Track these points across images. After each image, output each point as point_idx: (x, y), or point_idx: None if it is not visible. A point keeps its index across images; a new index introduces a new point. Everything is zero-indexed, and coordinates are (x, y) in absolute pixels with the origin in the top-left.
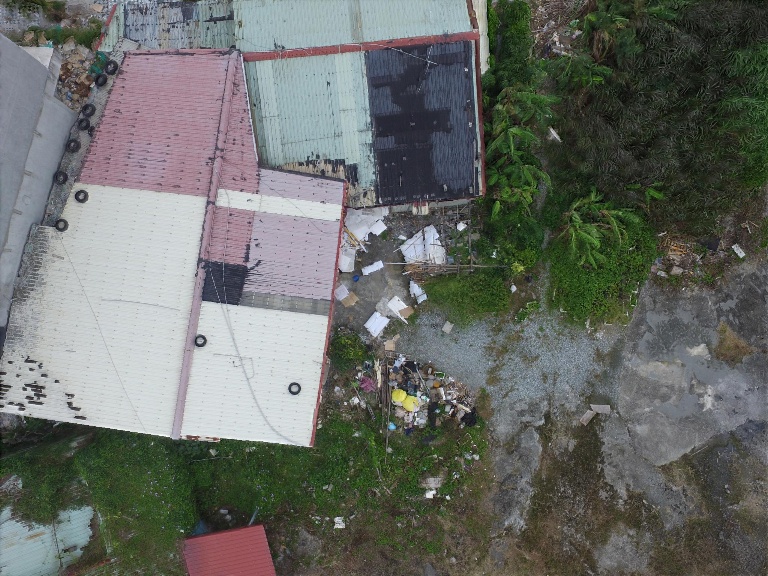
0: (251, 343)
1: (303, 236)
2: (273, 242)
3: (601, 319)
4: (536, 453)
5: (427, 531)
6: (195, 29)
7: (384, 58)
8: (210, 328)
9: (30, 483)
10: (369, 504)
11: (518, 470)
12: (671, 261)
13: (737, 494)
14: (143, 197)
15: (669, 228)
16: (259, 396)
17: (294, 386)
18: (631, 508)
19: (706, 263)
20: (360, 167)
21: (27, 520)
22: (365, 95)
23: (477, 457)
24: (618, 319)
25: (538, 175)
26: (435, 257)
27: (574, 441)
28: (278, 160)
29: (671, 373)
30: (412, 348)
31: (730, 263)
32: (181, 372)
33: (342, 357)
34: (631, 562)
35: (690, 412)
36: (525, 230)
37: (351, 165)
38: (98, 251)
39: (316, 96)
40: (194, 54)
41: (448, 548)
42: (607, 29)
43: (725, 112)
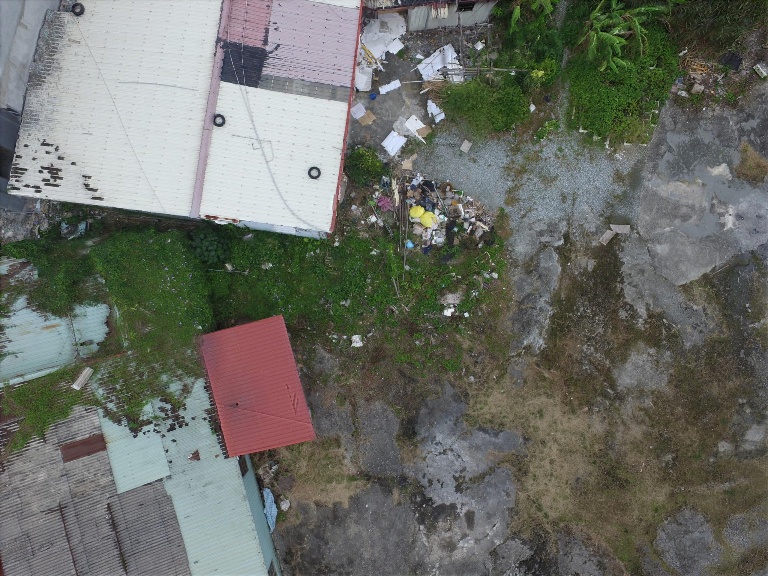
0: (270, 126)
1: (322, 22)
2: (292, 26)
3: (621, 139)
4: (555, 272)
5: (445, 349)
6: None
7: None
8: (229, 109)
9: (46, 271)
10: (387, 322)
11: (537, 289)
12: (692, 80)
13: (758, 313)
14: None
15: (690, 44)
16: (278, 179)
17: (314, 171)
18: (651, 327)
19: (727, 83)
20: None
21: (43, 310)
22: None
23: (496, 275)
24: (638, 137)
25: None
26: (453, 75)
27: (593, 261)
28: None
29: (692, 192)
30: (430, 167)
31: (751, 83)
32: (200, 151)
33: (360, 166)
34: (651, 380)
35: (711, 231)
36: (545, 44)
37: None
38: (115, 34)
39: None
40: None
41: (466, 367)
42: None
43: None
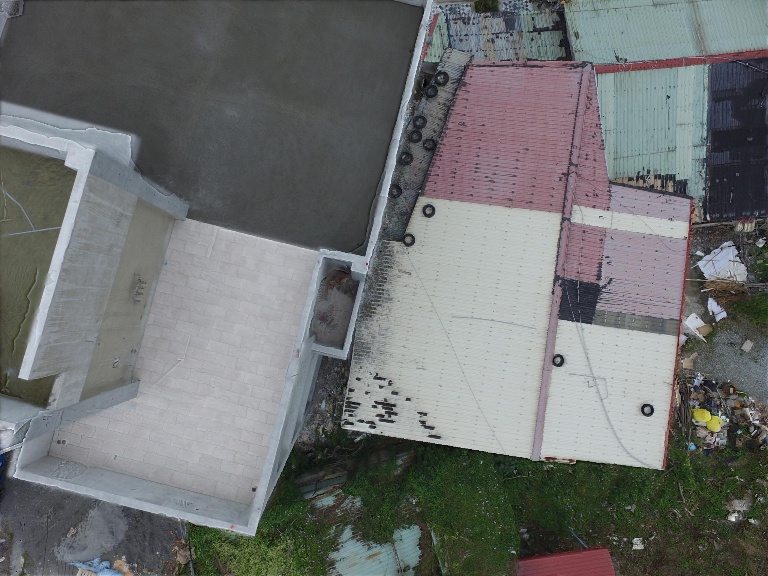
0: (605, 363)
1: (652, 254)
2: (624, 260)
3: None
4: None
5: (728, 554)
6: (519, 40)
7: (728, 72)
8: (566, 347)
9: (371, 501)
10: (669, 525)
11: None
12: None
13: None
14: (493, 212)
15: None
16: (613, 417)
17: (646, 408)
18: None
19: None
20: (690, 183)
21: (367, 539)
22: (704, 109)
23: None
24: None
25: None
26: (736, 274)
27: None
28: None
29: None
30: (710, 367)
31: None
32: (540, 392)
33: None
34: None
35: None
36: None
37: (681, 181)
38: (447, 267)
39: (654, 110)
40: (543, 66)
41: (749, 572)
42: None
43: None
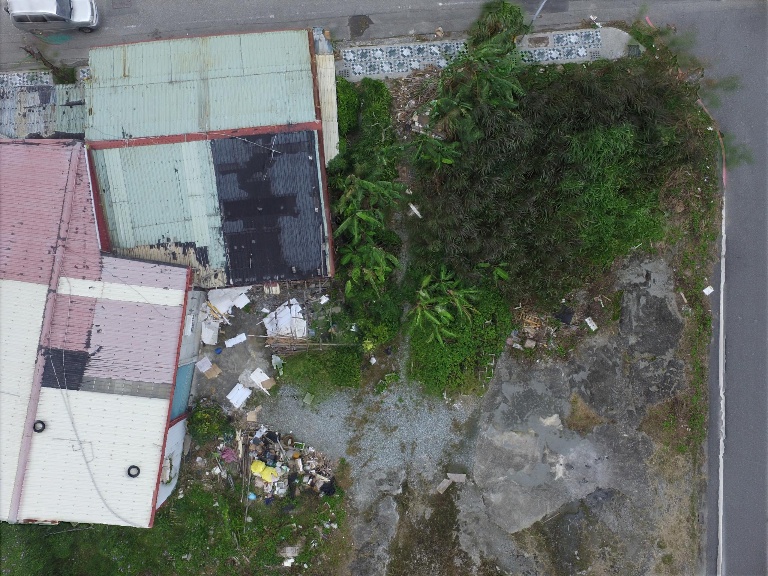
0: (91, 427)
1: (145, 321)
2: (115, 328)
3: (458, 390)
4: (393, 521)
5: None
6: (51, 113)
7: (230, 147)
8: (49, 413)
9: None
10: (229, 572)
11: (375, 538)
12: (526, 334)
13: (586, 560)
14: None
15: (522, 303)
16: (98, 479)
17: (134, 469)
18: (484, 574)
19: (560, 336)
20: (211, 250)
21: None
22: (213, 181)
23: (335, 526)
24: (473, 391)
25: (386, 257)
26: (296, 330)
27: (430, 509)
28: (129, 243)
29: (525, 443)
30: (274, 419)
31: (583, 336)
32: (19, 457)
33: (198, 431)
34: None
35: (542, 481)
36: (381, 305)
37: (202, 248)
38: None
39: (165, 182)
40: (39, 144)
41: None
42: (450, 118)
43: (566, 197)
